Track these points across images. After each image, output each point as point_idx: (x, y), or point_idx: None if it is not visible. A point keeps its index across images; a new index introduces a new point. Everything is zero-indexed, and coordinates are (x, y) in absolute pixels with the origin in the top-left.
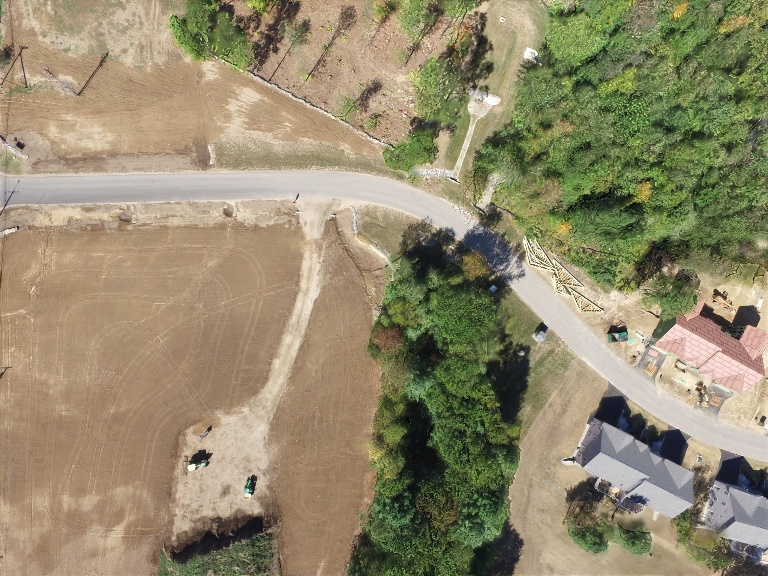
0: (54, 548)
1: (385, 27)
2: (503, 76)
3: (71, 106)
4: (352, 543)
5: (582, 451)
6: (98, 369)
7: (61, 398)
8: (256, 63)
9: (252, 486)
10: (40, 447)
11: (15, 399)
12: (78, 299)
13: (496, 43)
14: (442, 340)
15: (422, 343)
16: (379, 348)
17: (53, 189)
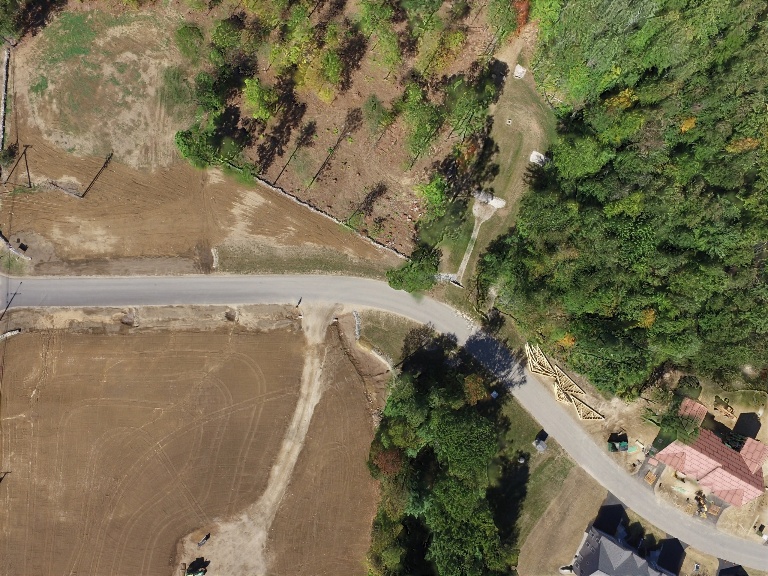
0: None
1: (391, 129)
2: (509, 178)
3: (75, 208)
4: None
5: (580, 562)
6: (97, 475)
7: (60, 504)
8: (261, 166)
9: None
10: (38, 554)
11: (14, 505)
12: (78, 404)
13: (502, 145)
14: (442, 454)
15: (422, 452)
16: (379, 468)
17: (55, 291)
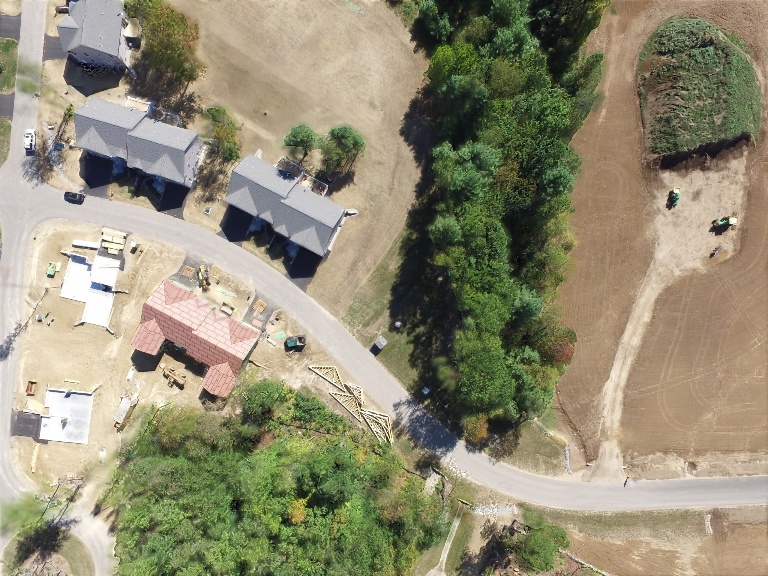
0: None
1: None
2: None
3: None
4: None
5: None
6: None
7: None
8: None
9: (672, 199)
10: None
11: None
12: None
13: None
14: None
15: (504, 337)
16: None
17: None
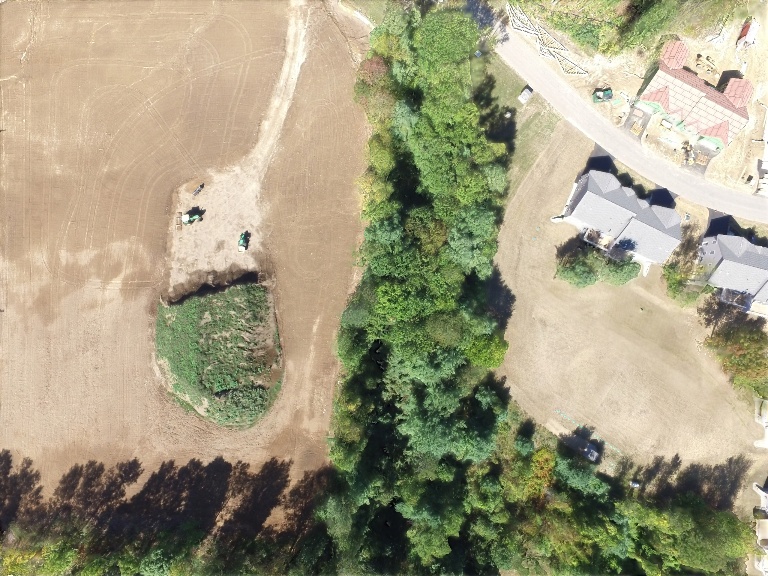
0: (54, 300)
1: None
2: None
3: None
4: (346, 301)
5: (570, 205)
6: (90, 130)
7: (55, 158)
8: None
9: (246, 241)
10: (36, 205)
11: (10, 160)
12: (68, 64)
13: None
14: (427, 86)
15: None
16: (365, 82)
17: None
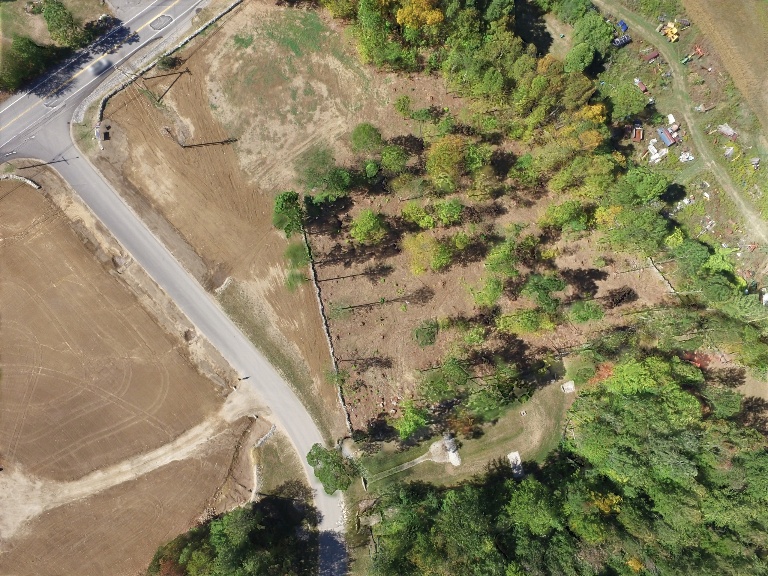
0: None
1: (439, 331)
2: (480, 450)
3: (170, 149)
4: None
5: None
6: None
7: None
8: (324, 260)
9: None
10: None
11: None
12: (20, 282)
13: (502, 423)
14: None
15: None
16: (159, 568)
17: (93, 189)
